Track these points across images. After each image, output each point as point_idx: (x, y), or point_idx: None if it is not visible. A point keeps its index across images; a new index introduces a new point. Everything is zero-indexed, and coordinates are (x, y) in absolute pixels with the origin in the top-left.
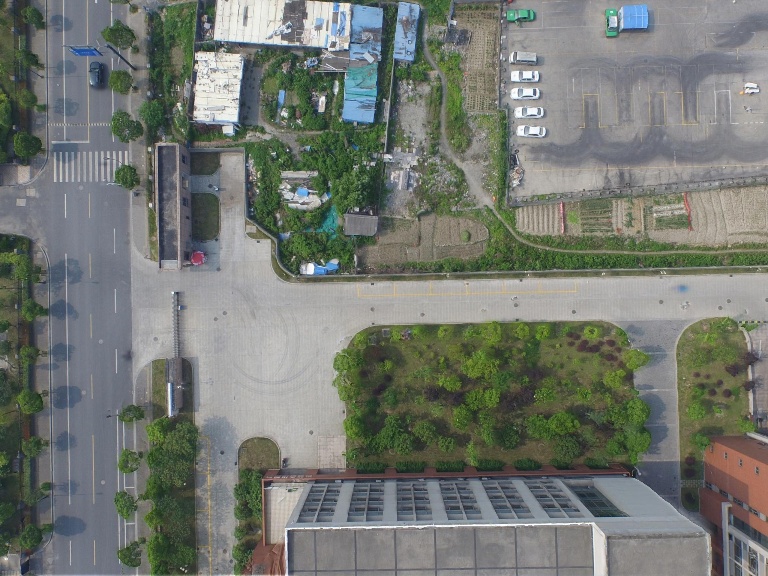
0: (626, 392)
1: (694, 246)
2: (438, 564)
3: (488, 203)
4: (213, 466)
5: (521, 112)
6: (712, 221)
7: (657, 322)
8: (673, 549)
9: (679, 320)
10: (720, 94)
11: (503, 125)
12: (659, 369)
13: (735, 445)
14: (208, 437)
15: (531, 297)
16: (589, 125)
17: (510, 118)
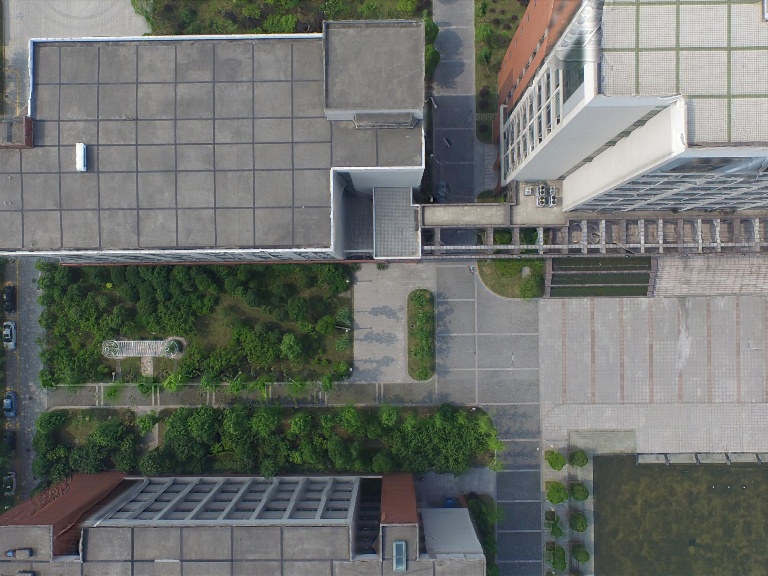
0: None
1: None
2: (178, 78)
3: None
4: (22, 99)
5: None
6: None
7: None
8: (390, 38)
9: None
10: None
11: None
12: (457, 7)
13: None
14: (17, 70)
15: None
16: None
17: None
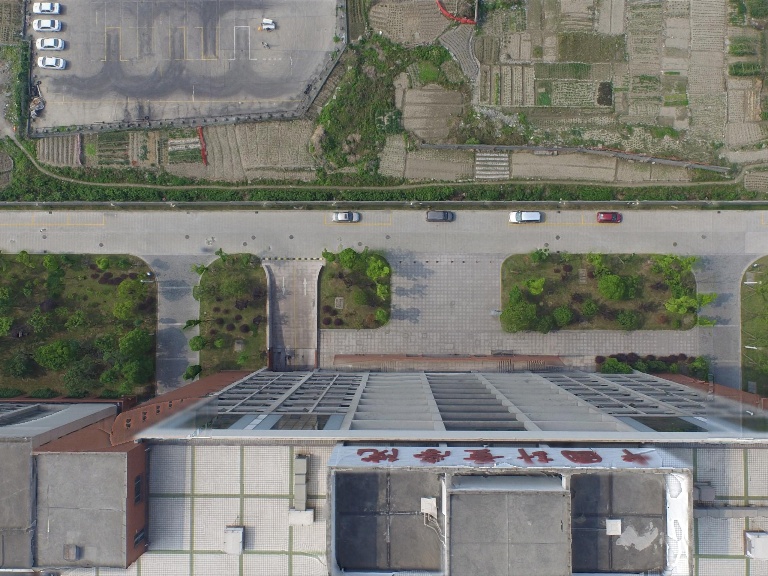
0: (147, 325)
1: (213, 181)
2: None
3: (9, 133)
4: None
5: (40, 43)
6: (227, 156)
7: (183, 257)
8: None
9: (204, 255)
10: (239, 30)
11: (23, 56)
12: (182, 303)
13: (220, 375)
14: None
15: (60, 229)
16: (110, 58)
17: (34, 50)
